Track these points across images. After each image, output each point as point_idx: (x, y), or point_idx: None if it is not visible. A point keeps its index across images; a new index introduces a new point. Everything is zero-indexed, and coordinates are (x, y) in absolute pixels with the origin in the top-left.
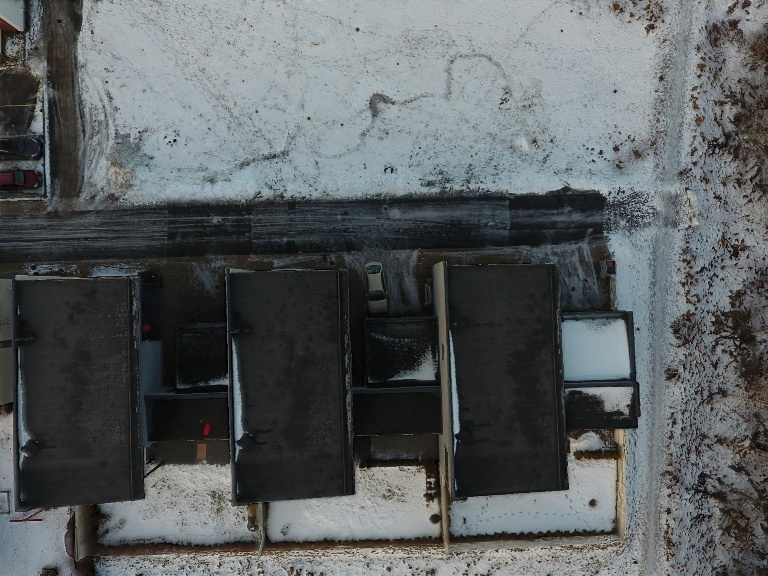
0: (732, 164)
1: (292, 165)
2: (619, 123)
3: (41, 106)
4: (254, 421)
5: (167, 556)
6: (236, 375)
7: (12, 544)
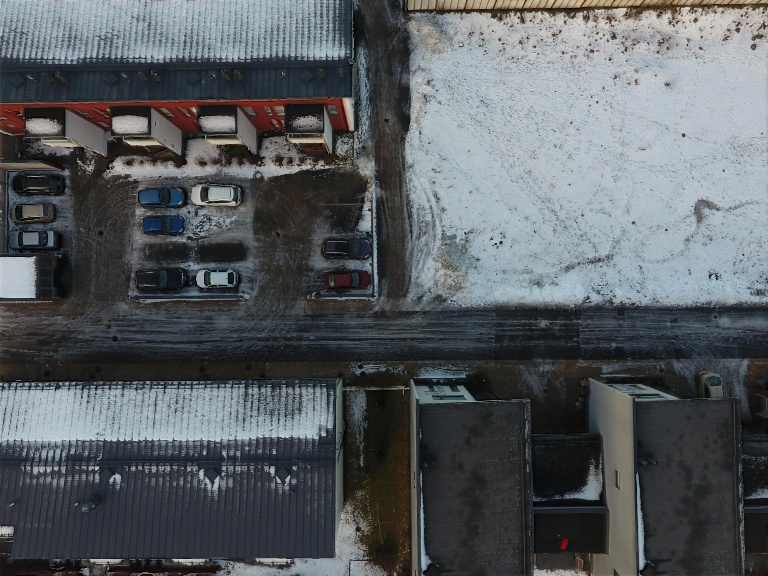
0: None
1: (616, 269)
2: None
3: (370, 206)
4: (655, 550)
5: None
6: (639, 505)
7: None
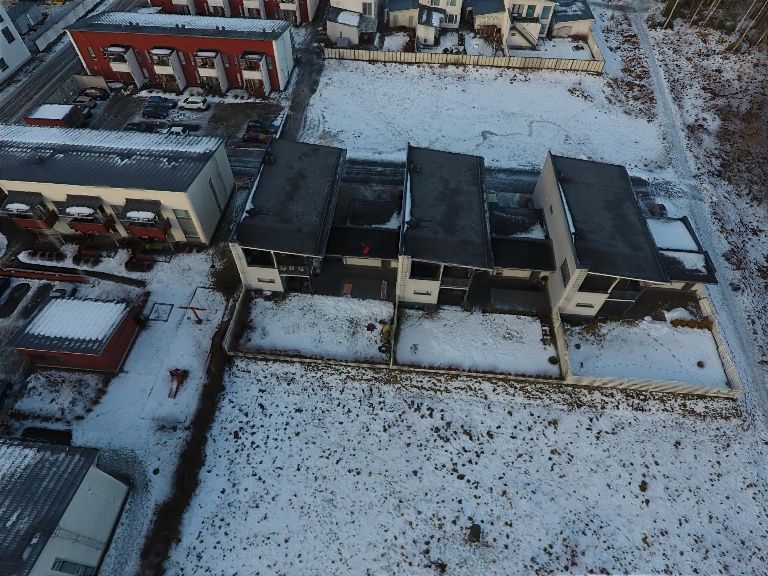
0: (729, 186)
1: None
2: (644, 155)
3: (282, 116)
4: (419, 214)
5: (296, 371)
6: (409, 189)
7: (158, 345)
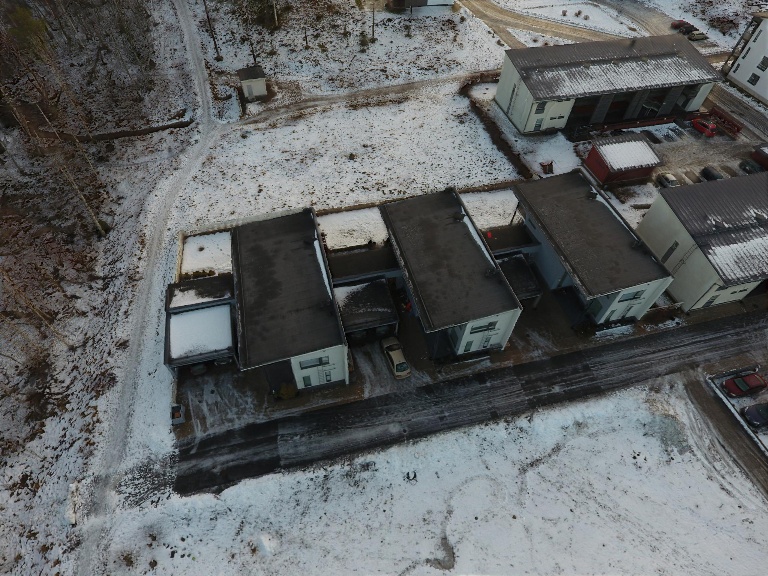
0: None
1: (511, 460)
2: None
3: None
4: (459, 228)
5: None
6: (483, 248)
7: None
